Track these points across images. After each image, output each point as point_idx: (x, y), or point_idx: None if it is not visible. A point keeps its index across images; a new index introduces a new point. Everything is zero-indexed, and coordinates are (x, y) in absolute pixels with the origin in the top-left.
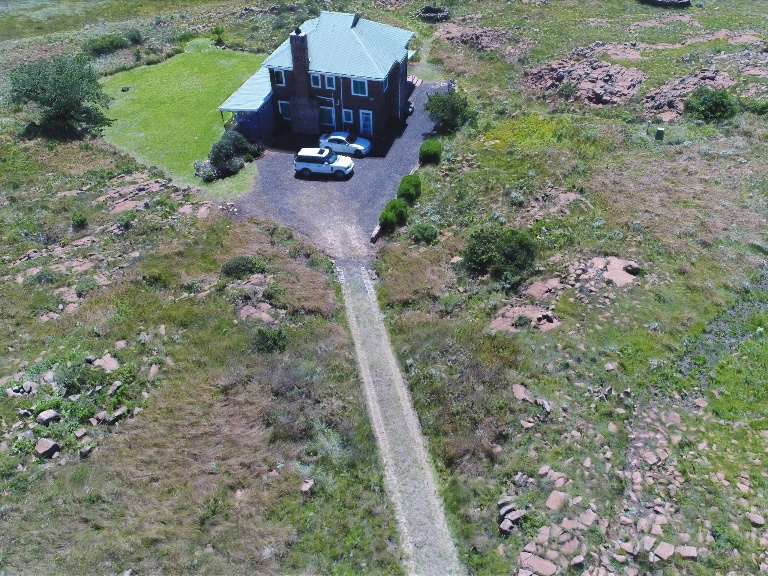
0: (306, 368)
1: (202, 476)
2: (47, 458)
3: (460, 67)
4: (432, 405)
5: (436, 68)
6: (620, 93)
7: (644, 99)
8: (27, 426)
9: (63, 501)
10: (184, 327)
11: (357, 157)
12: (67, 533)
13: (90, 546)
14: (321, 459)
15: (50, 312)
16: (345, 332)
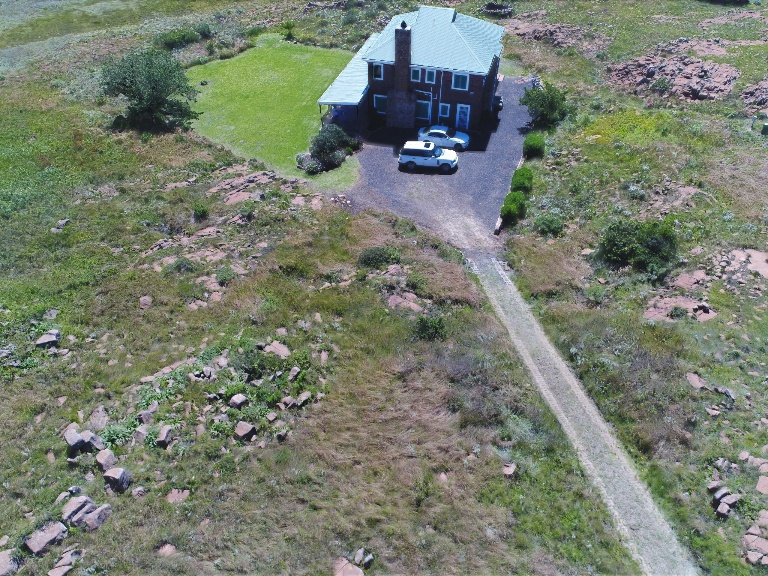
0: (476, 356)
1: (403, 460)
2: (247, 441)
3: (540, 63)
4: (610, 393)
5: (514, 64)
6: (717, 89)
7: (742, 95)
8: (219, 410)
9: (277, 482)
10: (339, 315)
11: (457, 151)
12: (288, 513)
13: (315, 526)
14: (518, 444)
15: (197, 300)
16: (497, 322)
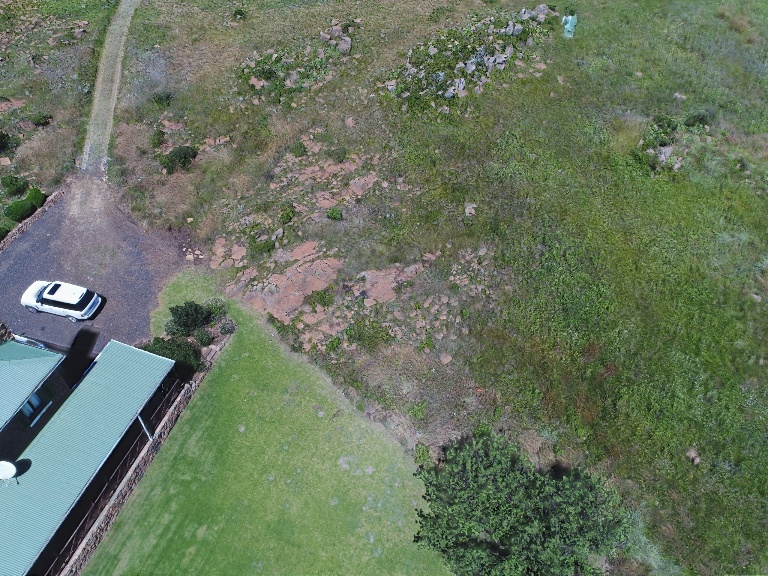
0: None
1: None
2: None
3: None
4: None
5: None
6: None
7: None
8: None
9: None
10: None
11: None
12: None
13: None
14: None
15: None
16: None
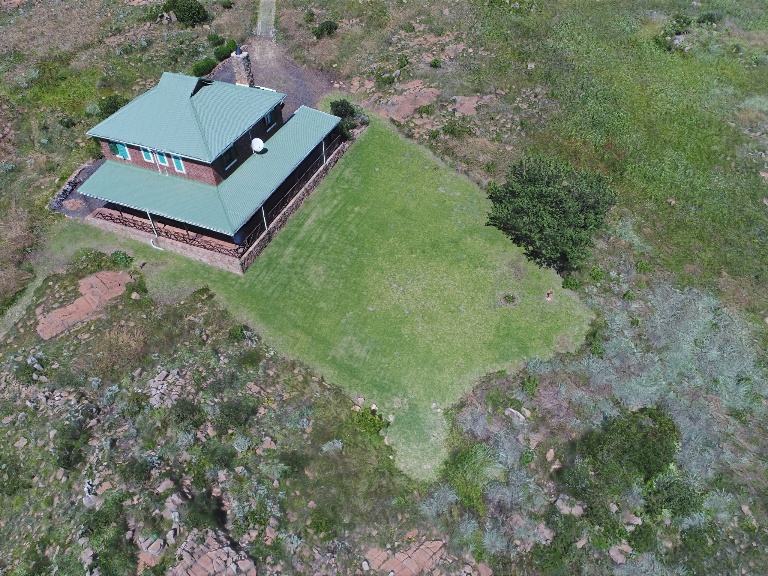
0: None
1: None
2: None
3: (15, 233)
4: None
5: (39, 254)
6: None
7: None
8: None
9: None
10: None
11: None
12: None
13: None
14: None
15: None
16: (278, 4)
